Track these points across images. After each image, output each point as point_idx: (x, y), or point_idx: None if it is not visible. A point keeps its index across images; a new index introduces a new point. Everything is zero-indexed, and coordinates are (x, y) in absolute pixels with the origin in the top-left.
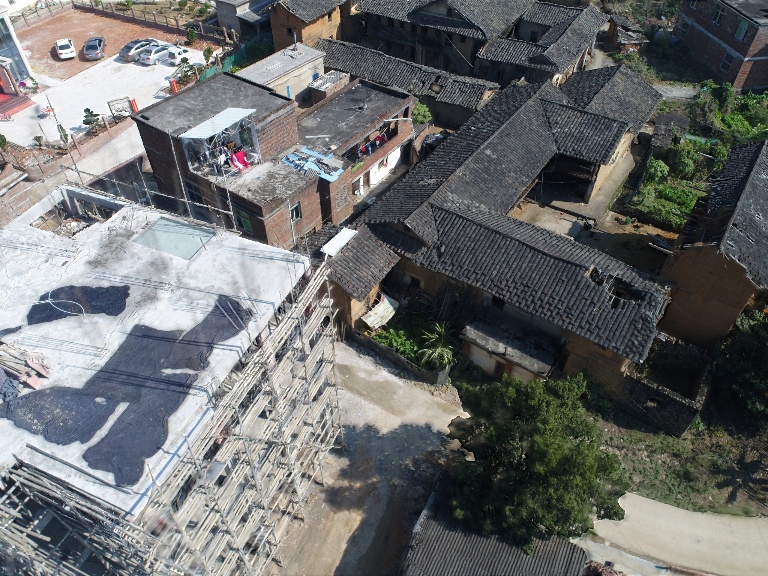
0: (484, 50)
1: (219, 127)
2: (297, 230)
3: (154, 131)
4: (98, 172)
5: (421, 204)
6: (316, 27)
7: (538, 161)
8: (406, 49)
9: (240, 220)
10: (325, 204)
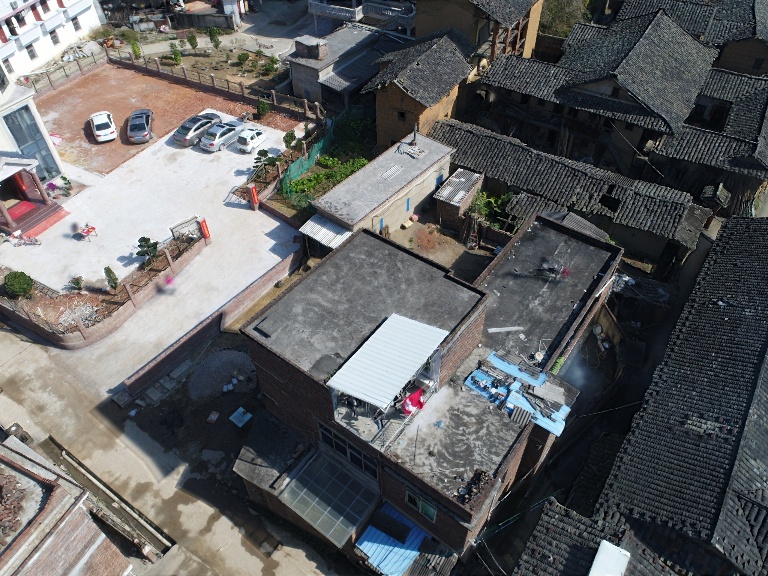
0: (662, 143)
1: (398, 375)
2: (494, 500)
3: (279, 359)
4: (161, 335)
5: (722, 494)
6: (434, 108)
7: None
8: (542, 131)
9: (414, 498)
10: (530, 449)
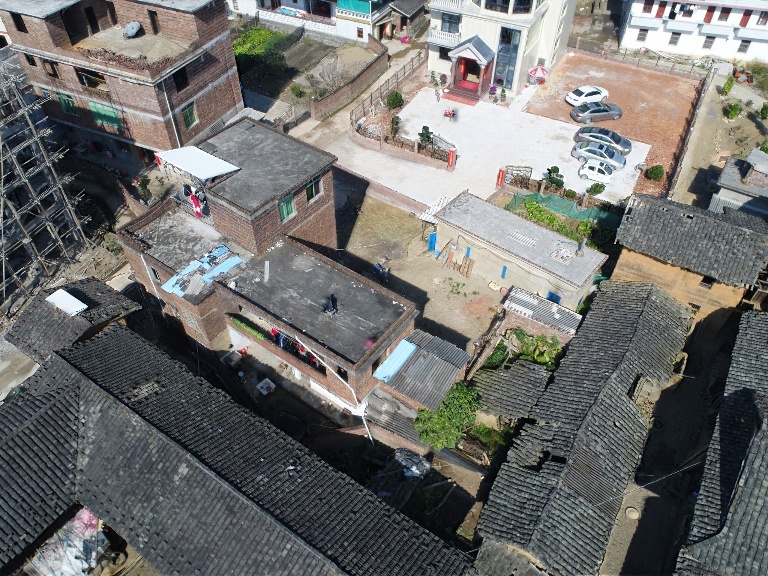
0: None
1: (177, 160)
2: None
3: None
4: (358, 166)
5: None
6: (663, 269)
7: (185, 574)
8: None
9: None
10: None
